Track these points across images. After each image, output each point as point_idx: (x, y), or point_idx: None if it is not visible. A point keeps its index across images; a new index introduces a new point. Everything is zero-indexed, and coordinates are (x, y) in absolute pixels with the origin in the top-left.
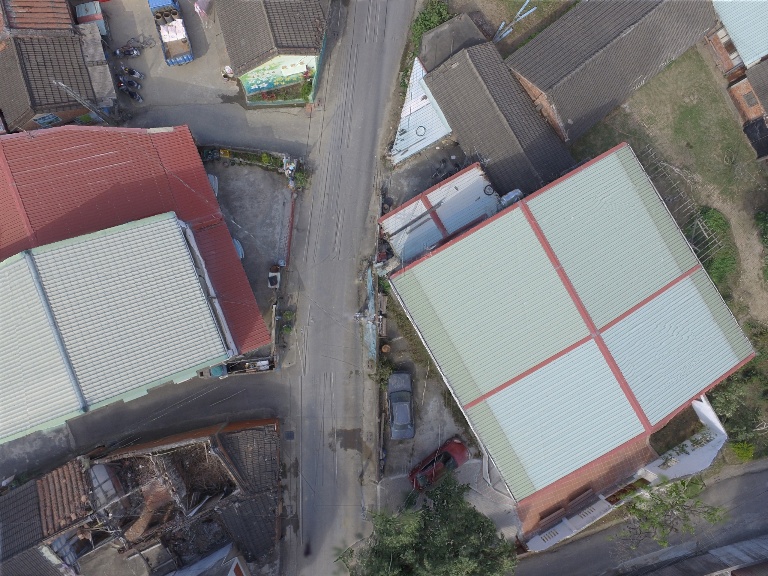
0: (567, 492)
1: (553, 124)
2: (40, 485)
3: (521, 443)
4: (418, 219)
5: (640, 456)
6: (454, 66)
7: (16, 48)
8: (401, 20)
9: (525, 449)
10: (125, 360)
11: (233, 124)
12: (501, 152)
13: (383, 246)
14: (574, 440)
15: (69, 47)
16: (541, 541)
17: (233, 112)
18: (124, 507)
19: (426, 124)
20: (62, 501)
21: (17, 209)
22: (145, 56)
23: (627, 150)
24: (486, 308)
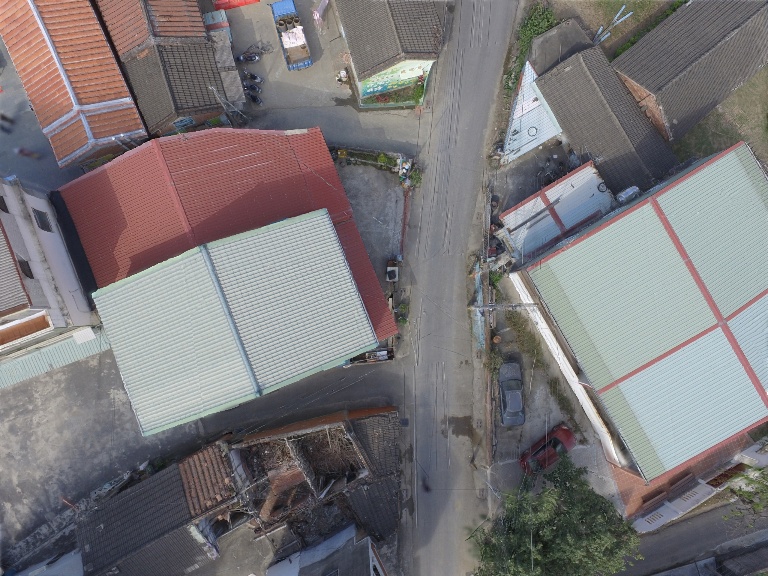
0: (668, 477)
1: (657, 124)
2: (182, 469)
3: (652, 426)
4: (537, 215)
5: (736, 442)
6: (567, 69)
7: (159, 55)
8: (504, 25)
9: (656, 431)
10: (290, 347)
11: (347, 126)
12: (612, 151)
13: (493, 241)
14: (702, 423)
15: (203, 54)
16: (646, 523)
17: (347, 114)
18: (254, 490)
19: (537, 125)
20: (206, 483)
21: (176, 207)
22: (264, 61)
23: (745, 148)
24: (618, 298)
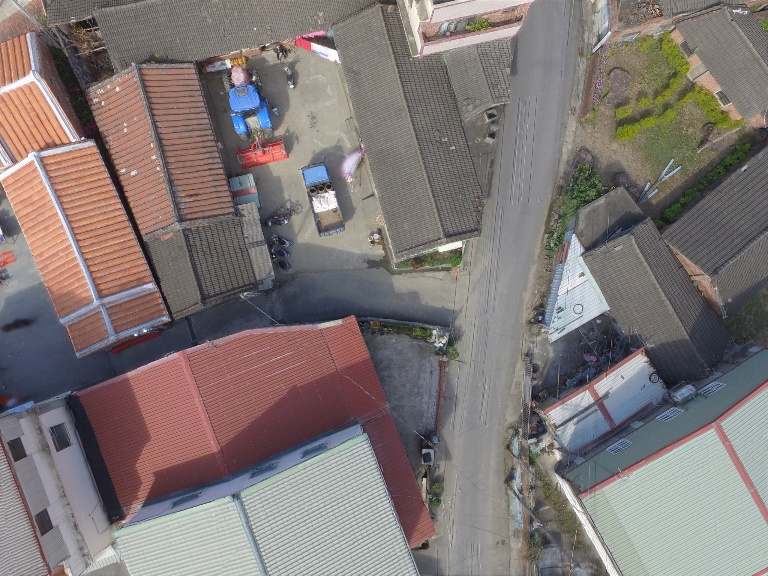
0: None
1: (710, 299)
2: None
3: None
4: (585, 410)
5: None
6: (617, 249)
7: (185, 240)
8: (545, 180)
9: None
10: None
11: (380, 290)
12: (664, 335)
13: (533, 418)
14: None
15: (231, 230)
16: None
17: (379, 278)
18: None
19: (583, 302)
20: None
21: (204, 425)
22: (292, 222)
23: None
24: (678, 530)
